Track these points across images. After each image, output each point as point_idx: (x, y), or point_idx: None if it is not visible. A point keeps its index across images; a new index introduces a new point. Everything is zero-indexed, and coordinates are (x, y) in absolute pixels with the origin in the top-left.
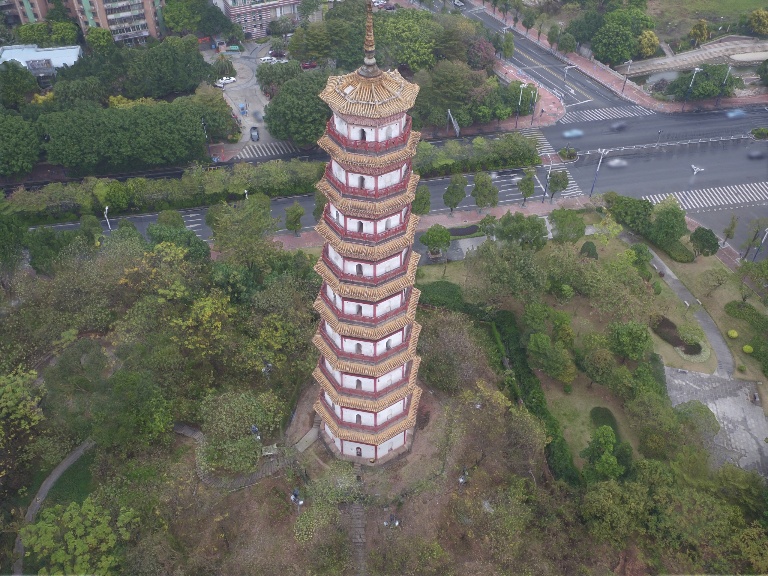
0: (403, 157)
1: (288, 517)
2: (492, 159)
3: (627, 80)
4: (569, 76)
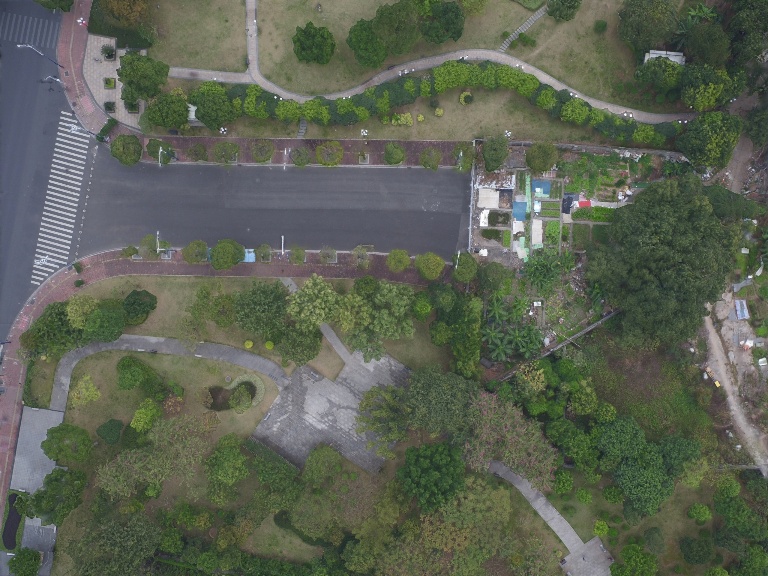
0: None
1: None
2: None
3: None
4: None
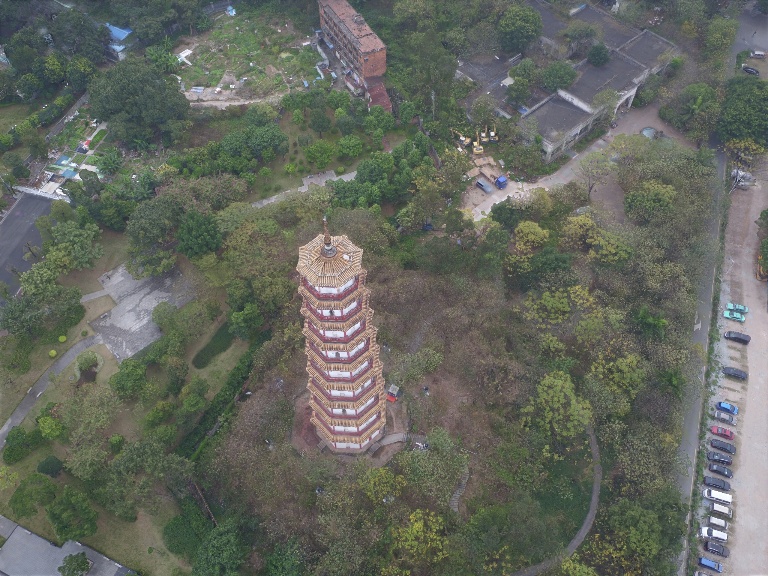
0: None
1: None
2: None
3: None
4: None
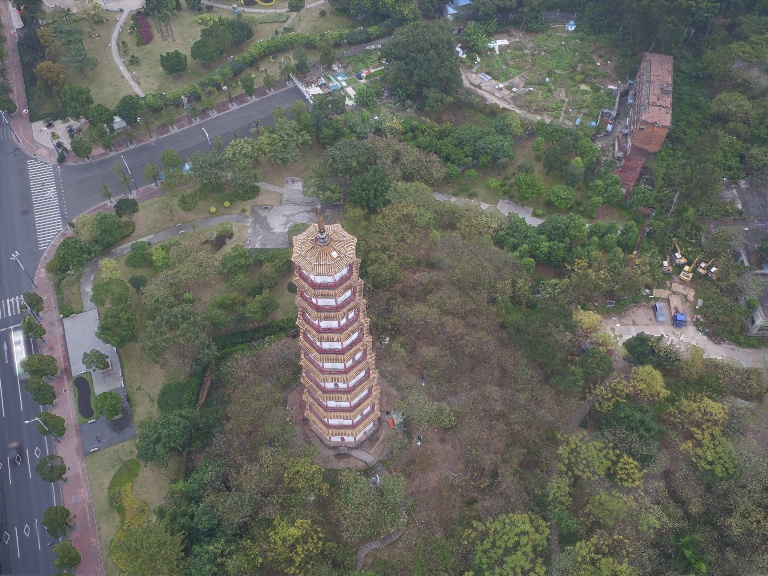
0: None
1: None
2: None
3: None
4: None
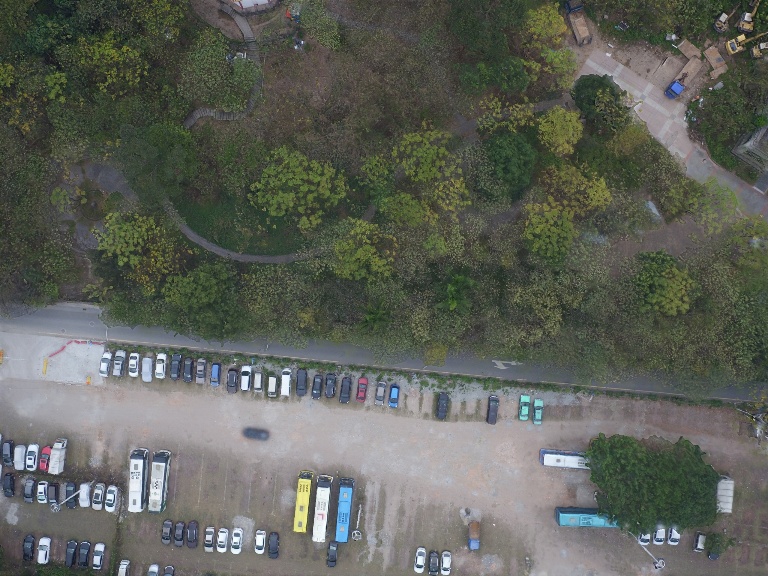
0: None
1: None
2: None
3: None
4: None
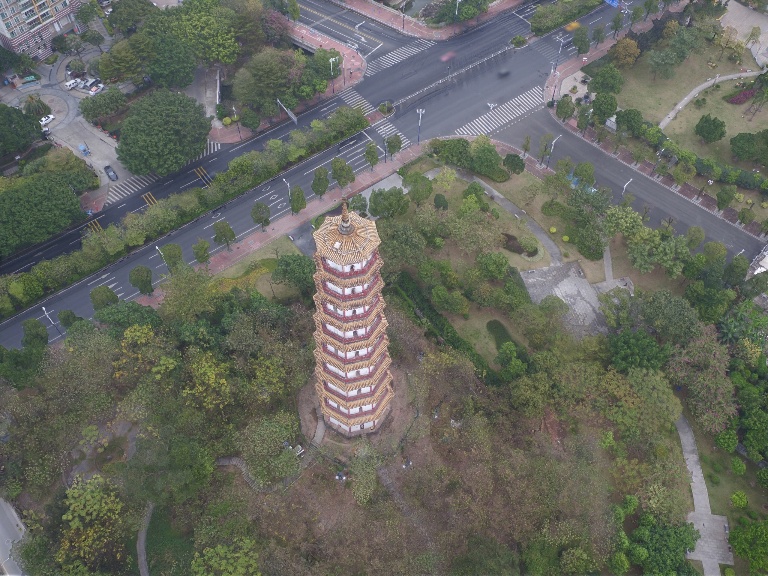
0: (378, 268)
1: (336, 490)
2: (332, 137)
3: (402, 14)
4: (354, 23)
